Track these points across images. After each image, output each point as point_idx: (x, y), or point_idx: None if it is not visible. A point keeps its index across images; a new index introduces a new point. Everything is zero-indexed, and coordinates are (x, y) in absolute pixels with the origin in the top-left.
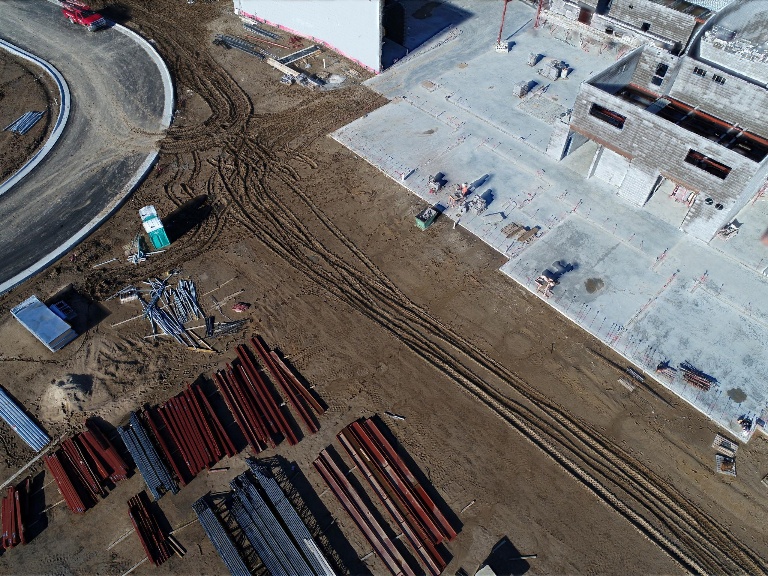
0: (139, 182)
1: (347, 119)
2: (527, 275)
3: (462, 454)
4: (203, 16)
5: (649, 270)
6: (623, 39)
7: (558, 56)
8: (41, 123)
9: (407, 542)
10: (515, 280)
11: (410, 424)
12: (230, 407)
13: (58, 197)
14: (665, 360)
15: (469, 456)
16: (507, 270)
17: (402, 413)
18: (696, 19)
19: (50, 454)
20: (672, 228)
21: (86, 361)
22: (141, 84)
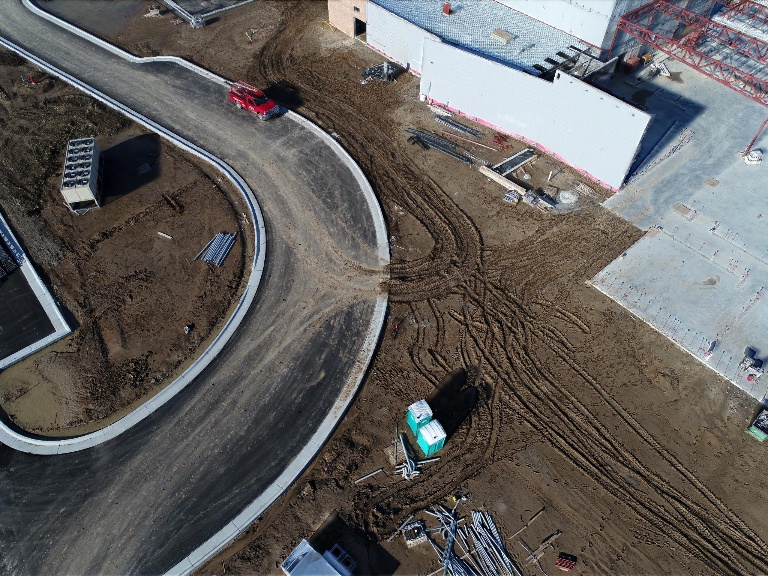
0: (376, 345)
1: (602, 258)
2: None
3: None
4: (384, 102)
5: None
6: None
7: None
8: (236, 250)
9: None
10: None
11: None
12: None
13: (284, 365)
14: None
15: None
16: None
17: None
18: None
19: None
20: None
21: None
22: (339, 196)
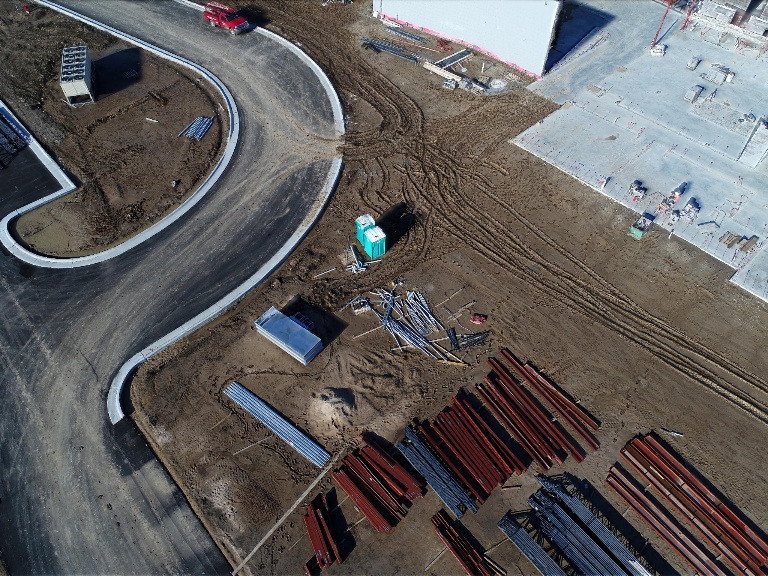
0: (332, 189)
1: (523, 125)
2: (761, 286)
3: (754, 472)
4: (342, 19)
5: None
6: None
7: (715, 60)
8: (214, 129)
9: (728, 564)
10: (750, 292)
11: (690, 441)
12: (502, 422)
13: (256, 205)
14: None
15: (762, 474)
16: (739, 281)
17: (678, 429)
18: None
19: (336, 470)
20: None
21: (340, 374)
22: (302, 88)
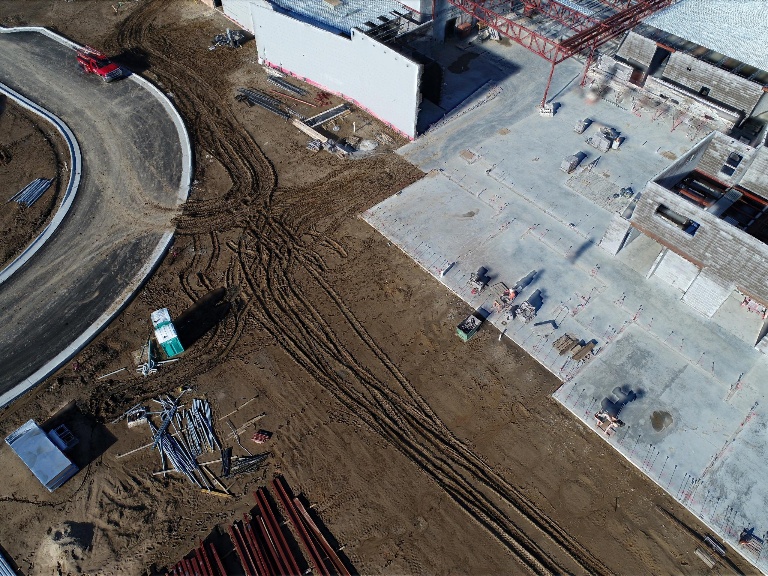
0: (152, 270)
1: (379, 196)
2: (584, 405)
3: None
4: (225, 65)
5: (723, 402)
6: (680, 105)
7: (608, 121)
8: (49, 193)
9: None
10: (570, 411)
11: None
12: (248, 574)
13: (64, 287)
14: (749, 526)
15: None
16: (561, 398)
17: None
18: (764, 88)
19: None
20: (746, 346)
21: (87, 504)
22: (157, 147)
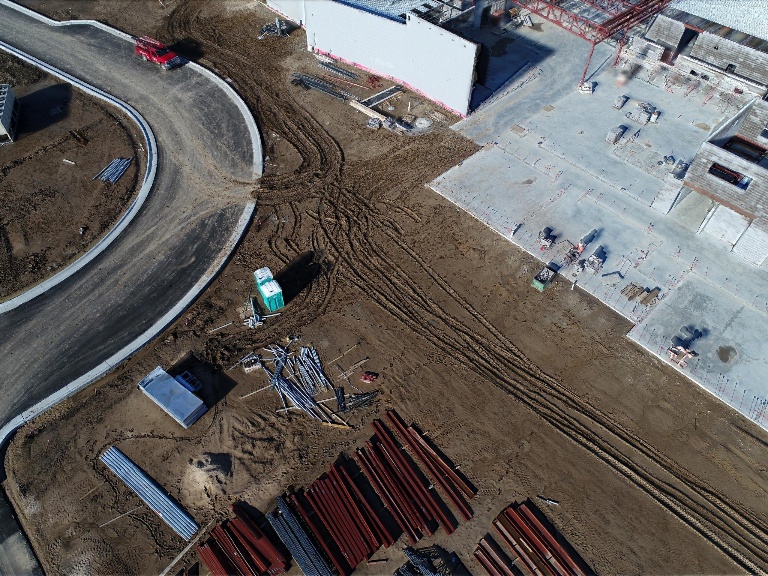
0: (241, 237)
1: (442, 167)
2: (656, 342)
3: (624, 544)
4: (276, 53)
5: None
6: (710, 81)
7: (643, 98)
8: (131, 171)
9: None
10: (645, 347)
11: (565, 509)
12: (378, 491)
13: (161, 253)
14: None
15: (632, 546)
16: (635, 336)
17: (555, 497)
18: None
19: (201, 544)
20: None
21: (220, 438)
22: (225, 128)
